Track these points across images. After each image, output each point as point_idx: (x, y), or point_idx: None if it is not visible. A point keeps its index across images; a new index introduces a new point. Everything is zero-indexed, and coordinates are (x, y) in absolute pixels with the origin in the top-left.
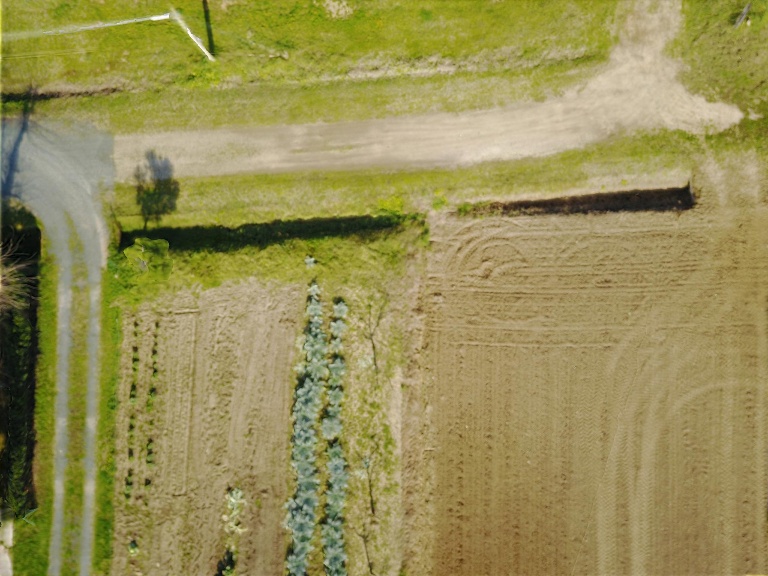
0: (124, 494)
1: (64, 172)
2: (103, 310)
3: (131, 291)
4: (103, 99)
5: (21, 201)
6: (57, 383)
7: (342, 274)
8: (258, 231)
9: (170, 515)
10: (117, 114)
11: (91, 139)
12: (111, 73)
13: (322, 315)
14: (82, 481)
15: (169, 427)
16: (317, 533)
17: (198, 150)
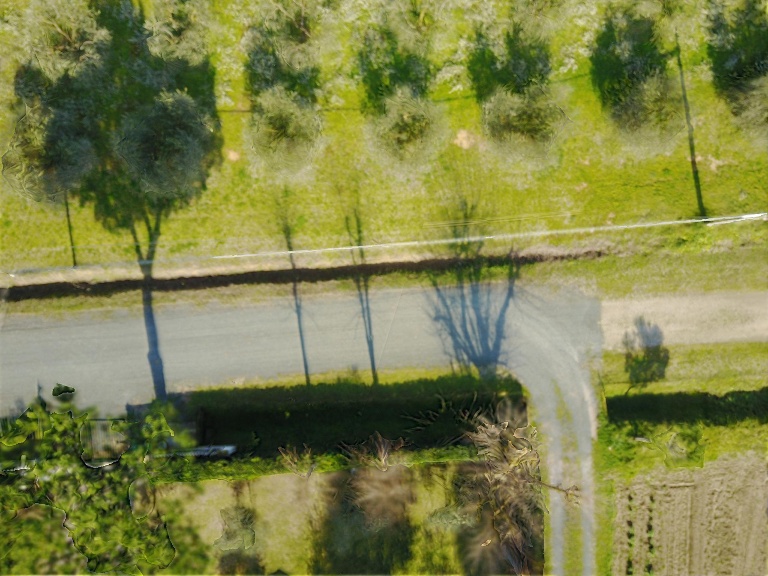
0: None
1: (551, 338)
2: (596, 482)
3: (628, 465)
4: (589, 263)
5: (507, 368)
6: (552, 557)
7: None
8: (747, 399)
9: None
10: (604, 279)
11: (577, 304)
12: (596, 236)
13: None
14: None
15: None
16: None
17: (688, 316)
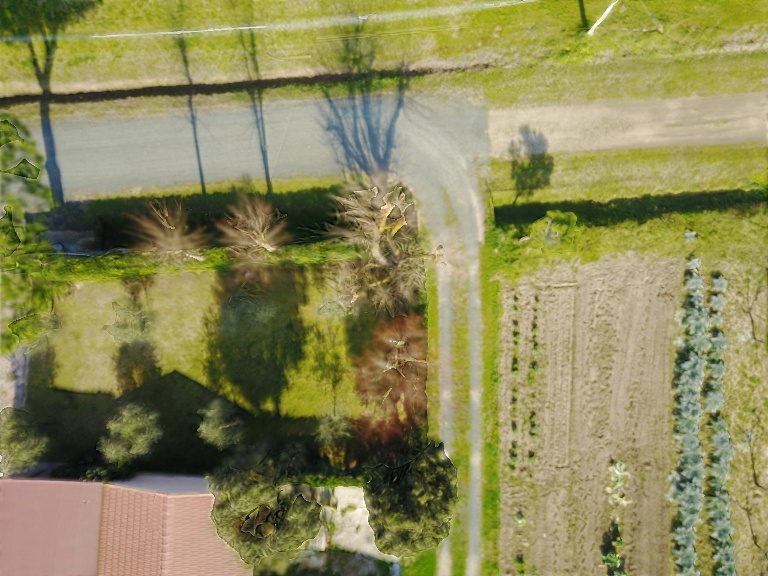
0: (509, 465)
1: (440, 147)
2: (483, 284)
3: (513, 265)
4: (477, 75)
5: (398, 176)
6: (440, 356)
7: (721, 248)
8: (629, 205)
9: (554, 487)
10: (491, 89)
11: (466, 115)
12: (484, 49)
13: (702, 289)
14: (468, 452)
15: (551, 400)
16: (702, 506)
17: (572, 125)
